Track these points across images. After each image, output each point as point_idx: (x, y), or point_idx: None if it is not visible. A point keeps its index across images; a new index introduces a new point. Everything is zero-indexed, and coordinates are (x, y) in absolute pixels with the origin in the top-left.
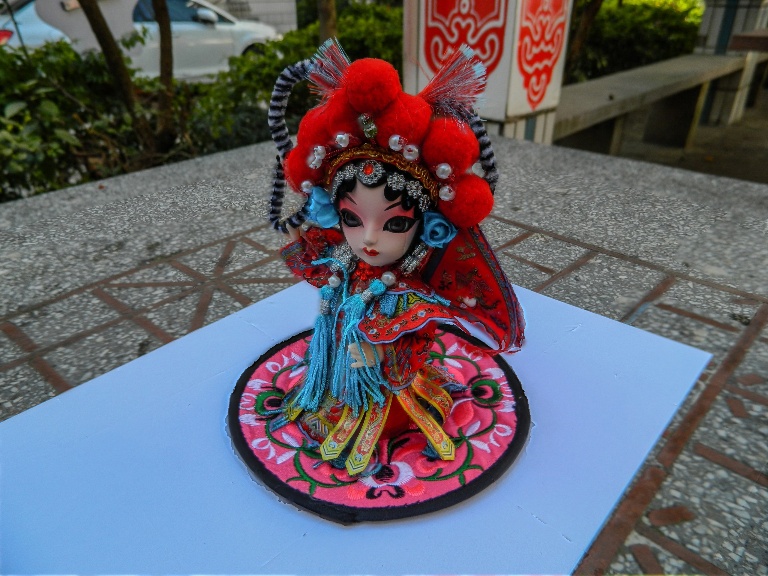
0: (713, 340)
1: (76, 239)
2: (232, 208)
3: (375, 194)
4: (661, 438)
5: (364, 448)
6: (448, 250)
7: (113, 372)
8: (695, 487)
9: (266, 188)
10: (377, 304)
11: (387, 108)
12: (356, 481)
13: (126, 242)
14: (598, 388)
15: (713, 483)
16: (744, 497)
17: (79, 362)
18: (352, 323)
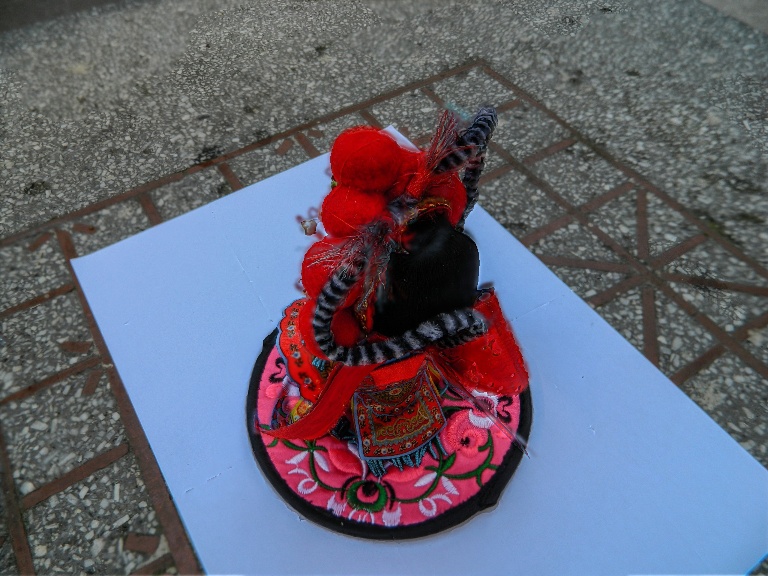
0: None
1: (763, 155)
2: None
3: None
4: None
5: None
6: None
7: (482, 211)
8: None
9: None
10: None
11: None
12: None
13: (759, 194)
14: None
15: None
16: None
17: (501, 190)
18: None
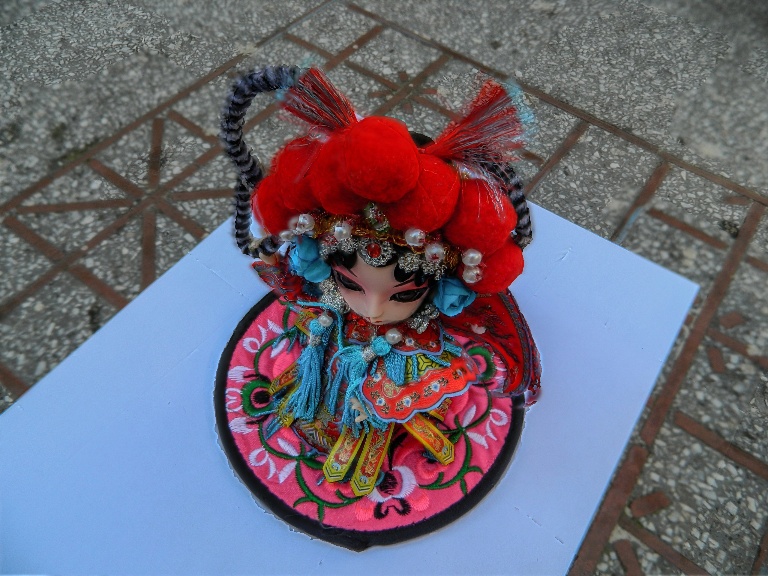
0: (701, 264)
1: None
2: (144, 51)
3: (382, 274)
4: (645, 408)
5: (368, 470)
6: None
7: (70, 359)
8: (672, 467)
9: (181, 7)
10: (381, 360)
11: (404, 198)
12: (362, 496)
13: (21, 124)
14: (588, 345)
15: (688, 461)
16: (714, 475)
17: (25, 346)
18: (355, 385)
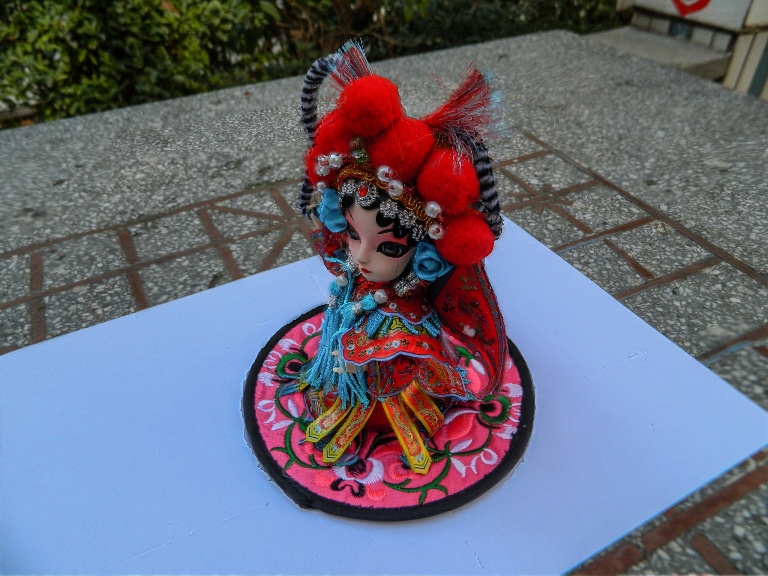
0: None
1: (206, 150)
2: None
3: (368, 216)
4: (661, 515)
5: (341, 441)
6: (453, 276)
7: (183, 299)
8: None
9: None
10: (367, 318)
11: (380, 136)
12: (329, 467)
13: (244, 161)
14: (621, 436)
15: None
16: None
17: (162, 283)
18: (339, 331)
